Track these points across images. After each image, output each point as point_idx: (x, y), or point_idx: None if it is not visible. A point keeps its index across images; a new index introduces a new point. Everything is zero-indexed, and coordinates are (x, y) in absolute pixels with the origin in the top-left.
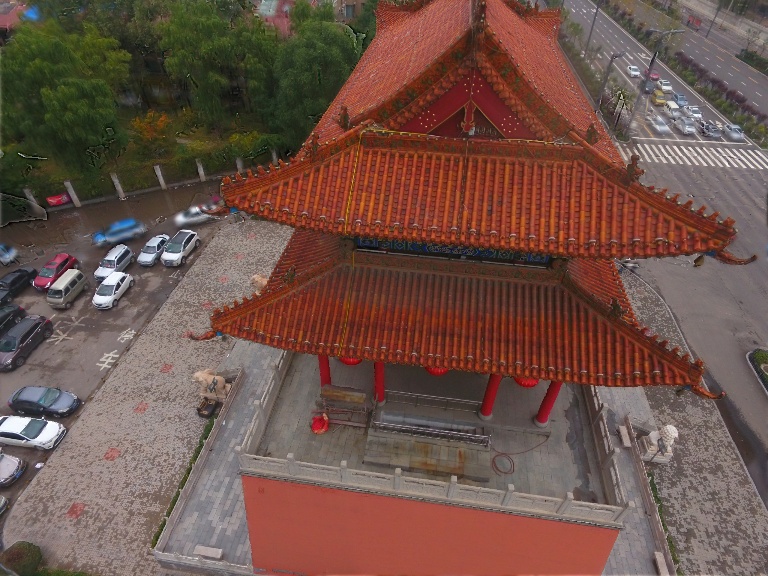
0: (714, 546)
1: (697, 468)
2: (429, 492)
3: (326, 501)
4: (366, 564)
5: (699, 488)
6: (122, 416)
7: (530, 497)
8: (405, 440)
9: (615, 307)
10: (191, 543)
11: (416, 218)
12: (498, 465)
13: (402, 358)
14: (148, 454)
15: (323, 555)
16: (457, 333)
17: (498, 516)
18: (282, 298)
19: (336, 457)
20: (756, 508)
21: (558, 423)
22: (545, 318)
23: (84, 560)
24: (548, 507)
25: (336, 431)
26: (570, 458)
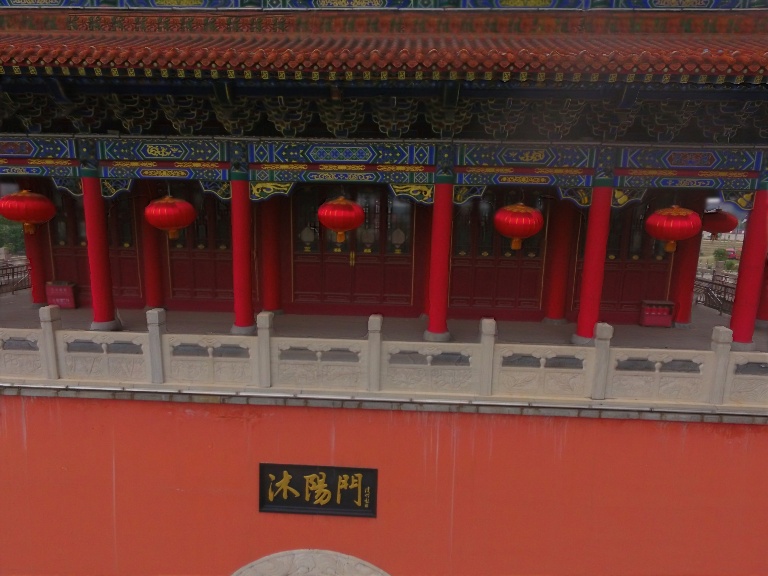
0: None
1: None
2: None
3: None
4: None
5: None
6: None
7: None
8: None
9: None
10: None
11: None
12: None
13: None
14: None
15: None
16: None
17: None
18: None
19: None
20: None
21: None
22: None
23: None
24: None
25: None
26: None
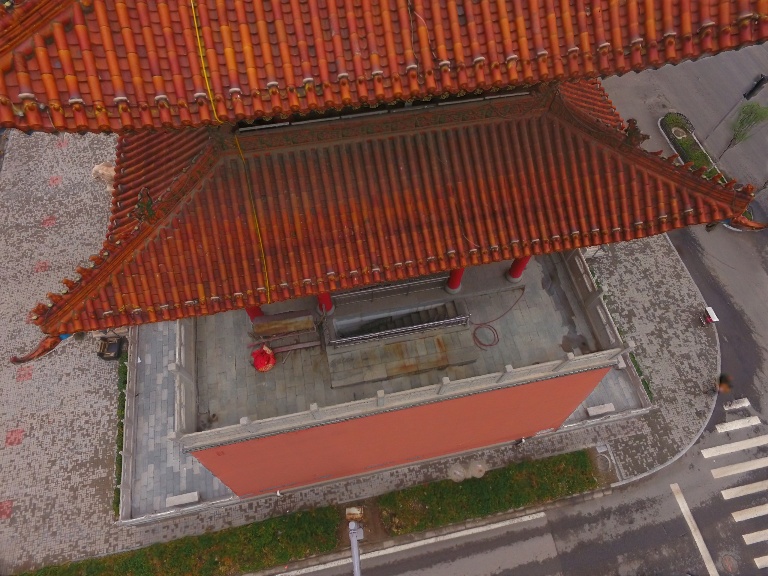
0: (651, 318)
1: (629, 251)
2: (417, 396)
3: (302, 437)
4: (357, 459)
5: (633, 270)
6: (4, 391)
7: (528, 369)
8: (373, 347)
9: (632, 133)
10: (159, 497)
11: (339, 60)
12: (481, 339)
13: (360, 279)
14: (61, 422)
15: (310, 467)
16: (425, 222)
17: (493, 392)
18: (147, 244)
19: (298, 392)
20: (680, 273)
21: (530, 270)
22: (535, 168)
23: (42, 554)
24: (545, 370)
25: (286, 361)
26: (551, 306)
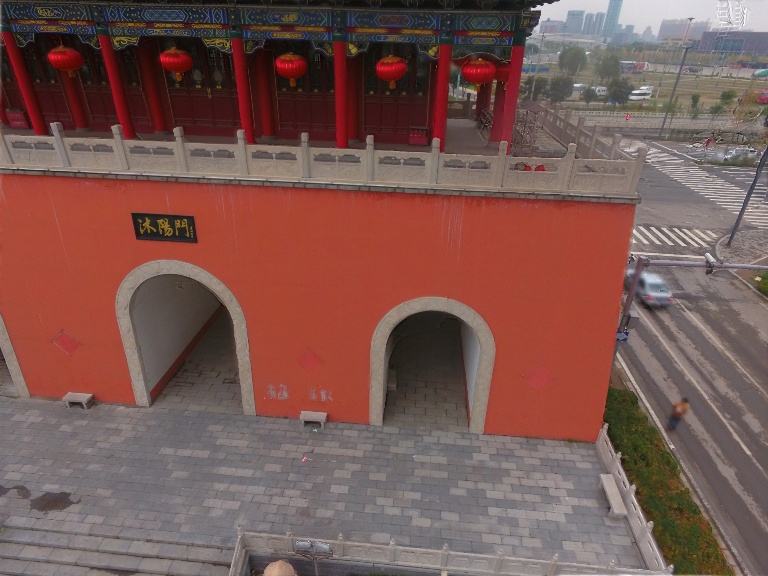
0: None
1: None
2: None
3: None
4: None
5: None
6: None
7: None
8: None
9: None
10: (611, 536)
11: None
12: None
13: None
14: None
15: None
16: None
17: None
18: None
19: None
20: None
21: None
22: None
23: None
24: None
25: None
26: None
